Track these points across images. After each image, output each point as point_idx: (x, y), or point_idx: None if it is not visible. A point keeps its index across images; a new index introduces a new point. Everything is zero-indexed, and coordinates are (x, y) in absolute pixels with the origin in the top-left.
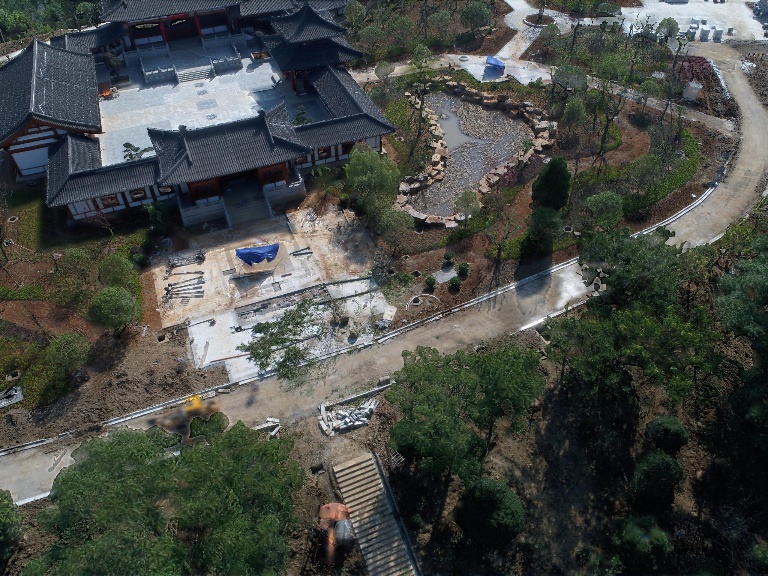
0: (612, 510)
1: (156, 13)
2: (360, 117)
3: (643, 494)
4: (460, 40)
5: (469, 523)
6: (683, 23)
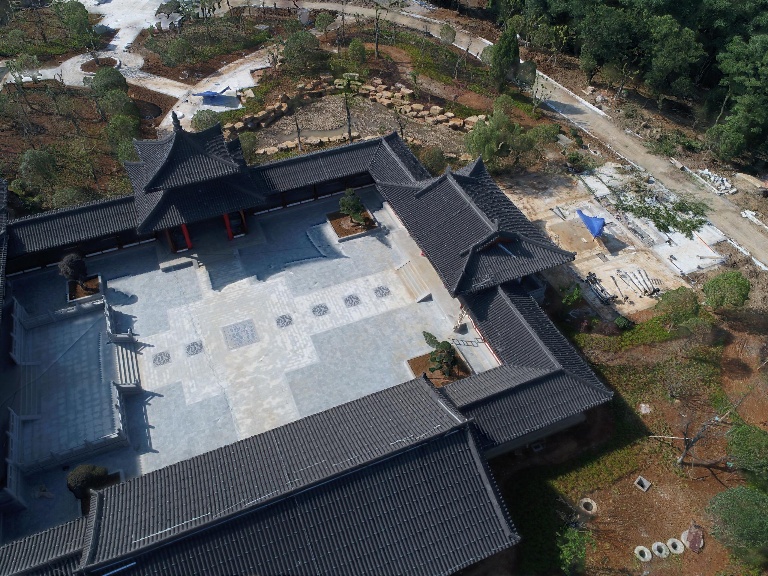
0: (694, 118)
1: None
2: None
3: (680, 107)
4: (133, 112)
5: (767, 131)
6: (158, 4)
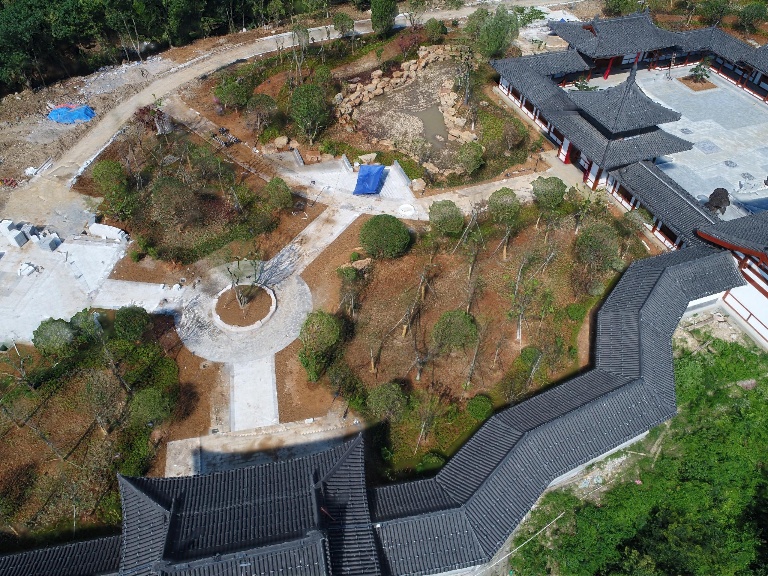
0: None
1: None
2: (522, 59)
3: None
4: None
5: None
6: None
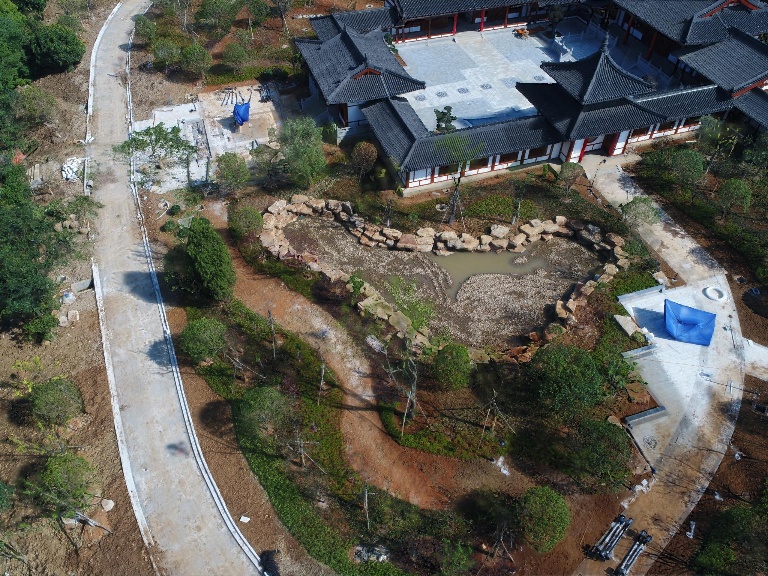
0: None
1: (623, 1)
2: (413, 139)
3: None
4: None
5: None
6: None
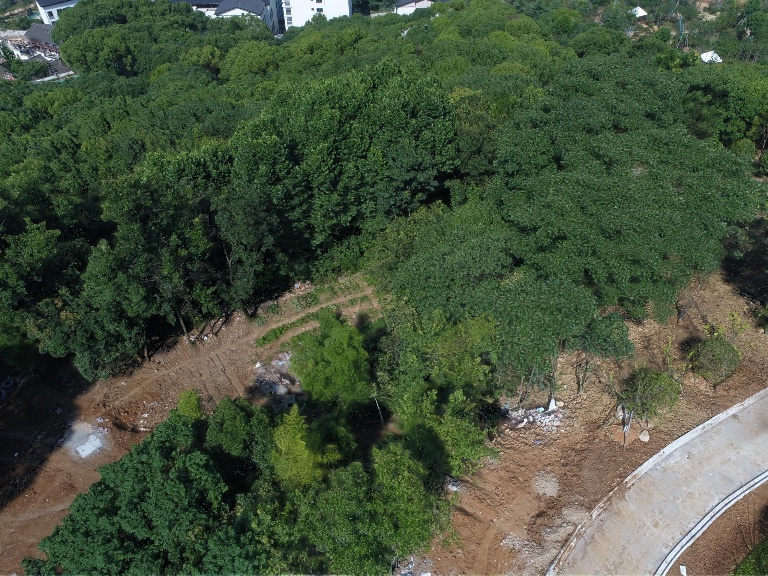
0: None
1: None
2: None
3: None
4: None
5: None
6: None
